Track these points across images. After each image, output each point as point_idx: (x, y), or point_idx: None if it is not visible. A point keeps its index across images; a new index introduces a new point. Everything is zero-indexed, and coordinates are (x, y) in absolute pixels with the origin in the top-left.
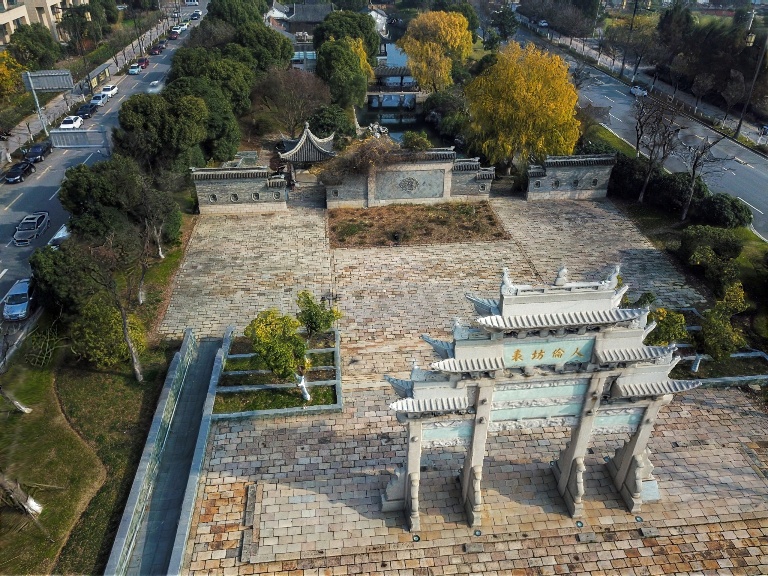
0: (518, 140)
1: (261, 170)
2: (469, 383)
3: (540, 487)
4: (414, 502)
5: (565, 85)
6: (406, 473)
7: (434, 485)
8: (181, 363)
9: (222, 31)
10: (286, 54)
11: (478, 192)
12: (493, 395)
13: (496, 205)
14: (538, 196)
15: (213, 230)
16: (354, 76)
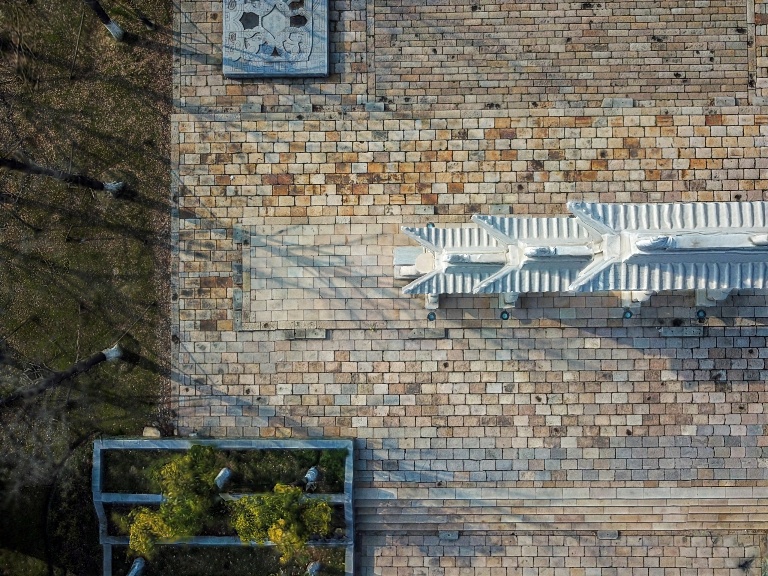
0: None
1: None
2: None
3: None
4: None
5: None
6: None
7: (668, 295)
8: None
9: None
10: None
11: None
12: None
13: None
14: None
15: None
16: None
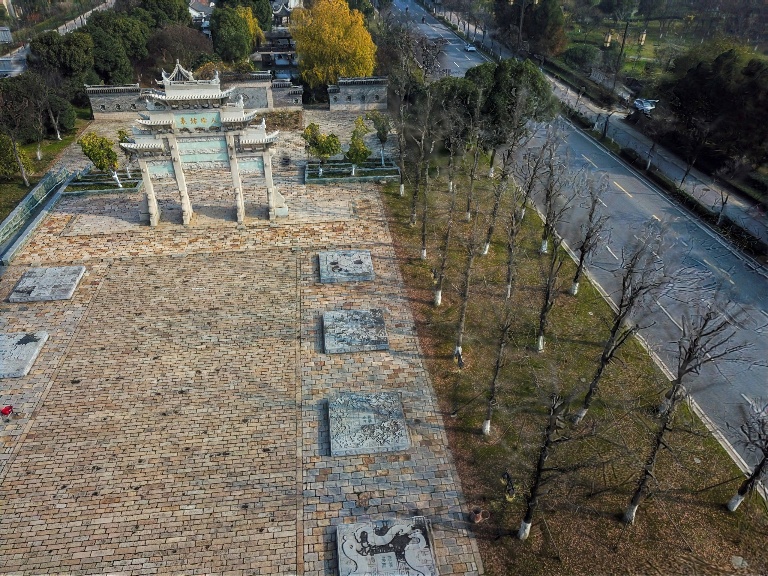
0: (327, 69)
1: (135, 87)
2: (162, 136)
3: (229, 213)
4: (150, 208)
5: (356, 29)
6: (146, 194)
7: None
8: (53, 177)
9: (139, 2)
10: (183, 17)
11: (293, 104)
12: (177, 144)
13: (306, 113)
14: (337, 108)
15: (101, 127)
16: (235, 34)
